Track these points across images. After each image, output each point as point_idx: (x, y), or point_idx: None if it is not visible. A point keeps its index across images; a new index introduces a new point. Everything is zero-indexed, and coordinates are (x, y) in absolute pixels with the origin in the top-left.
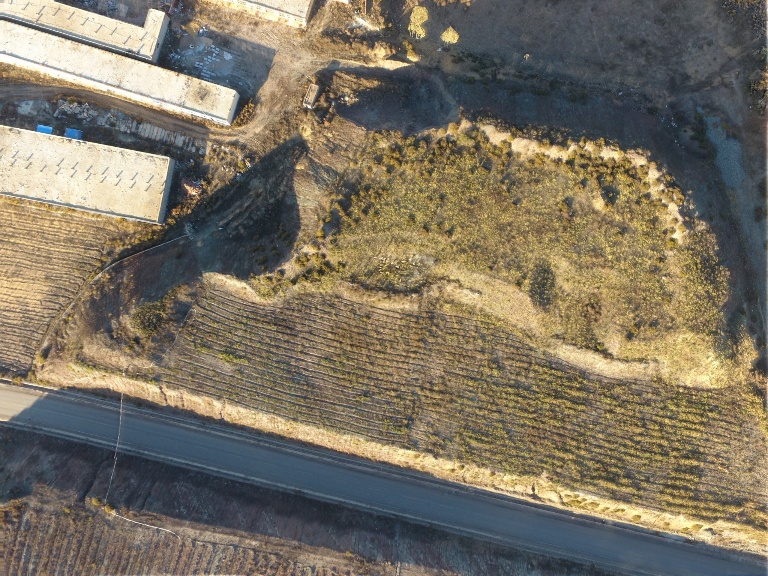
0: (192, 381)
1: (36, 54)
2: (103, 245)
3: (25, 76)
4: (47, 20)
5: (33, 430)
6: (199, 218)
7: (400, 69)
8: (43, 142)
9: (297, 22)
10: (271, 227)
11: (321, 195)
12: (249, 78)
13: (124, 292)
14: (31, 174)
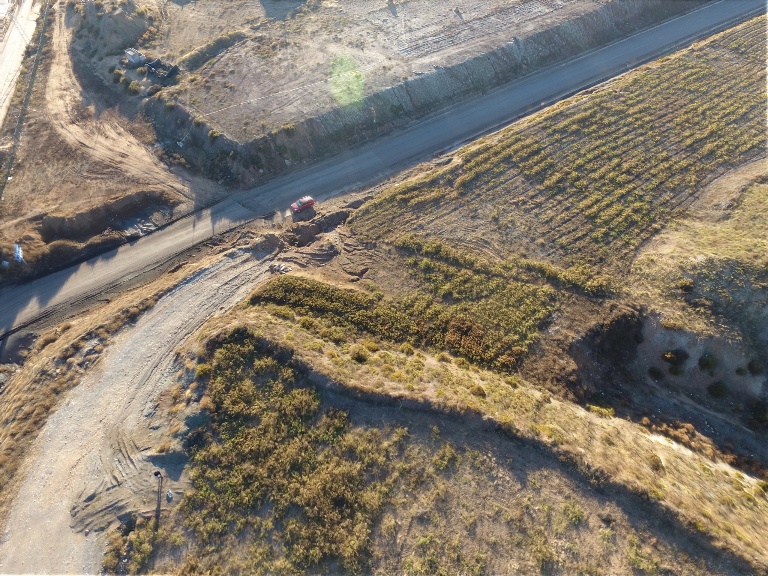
0: None
1: None
2: None
3: None
4: None
5: None
6: None
7: None
8: None
9: None
10: None
11: None
12: None
13: None
14: None
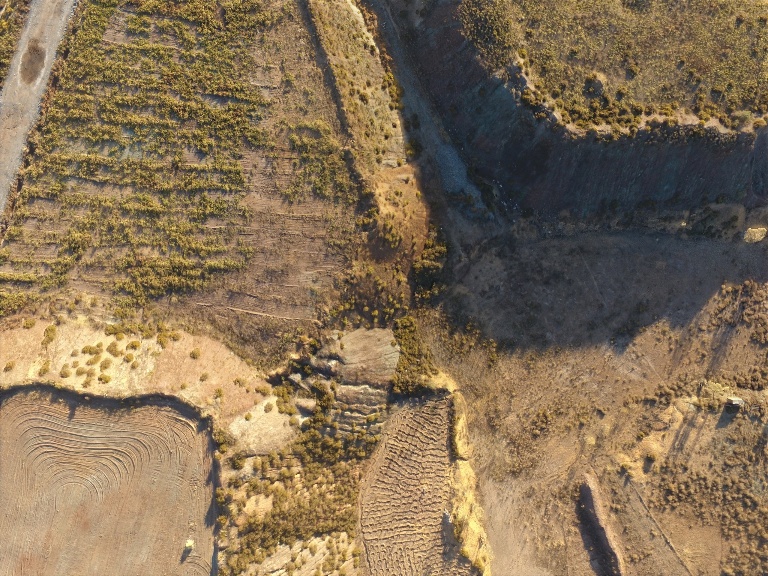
0: None
1: None
2: None
3: None
4: None
5: None
6: None
7: None
8: None
9: None
10: None
11: None
12: None
13: None
14: None
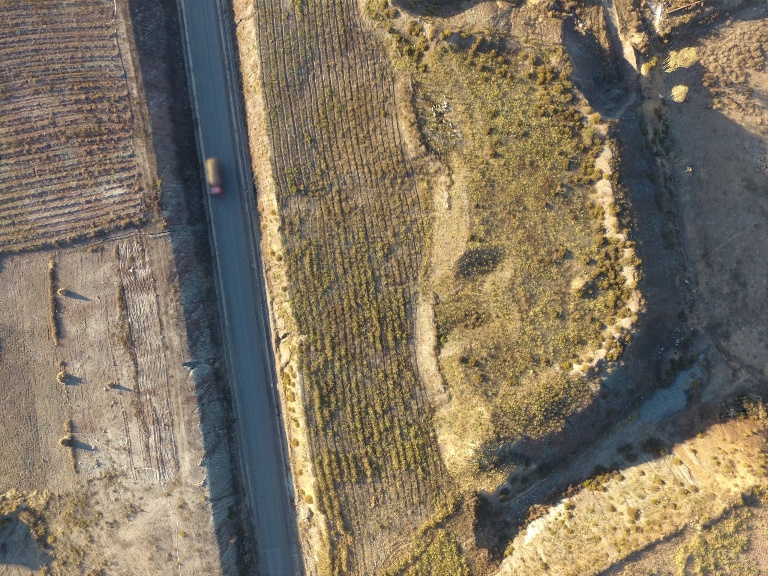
0: None
1: None
2: None
3: None
4: None
5: None
6: None
7: (628, 64)
8: None
9: None
10: None
11: (483, 23)
12: None
13: None
14: None
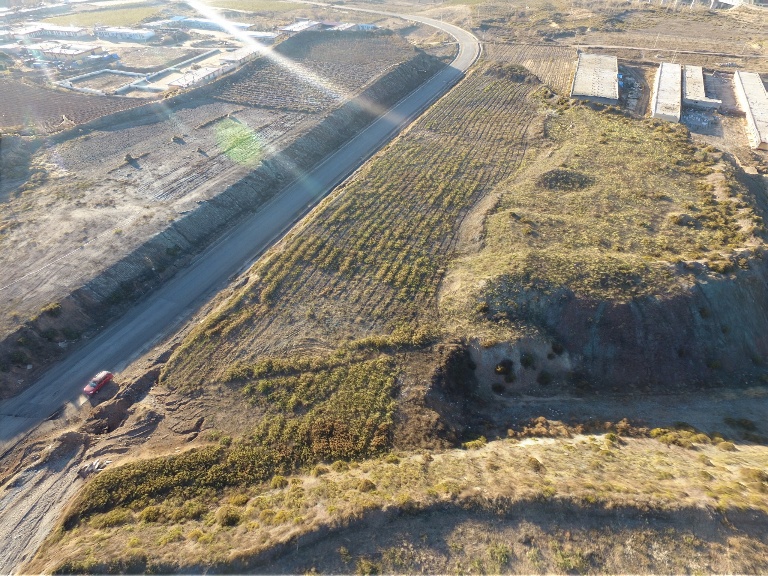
0: None
1: None
2: None
3: (650, 79)
4: (689, 79)
5: None
6: None
7: (749, 175)
8: None
9: None
10: None
11: None
12: None
13: None
14: None
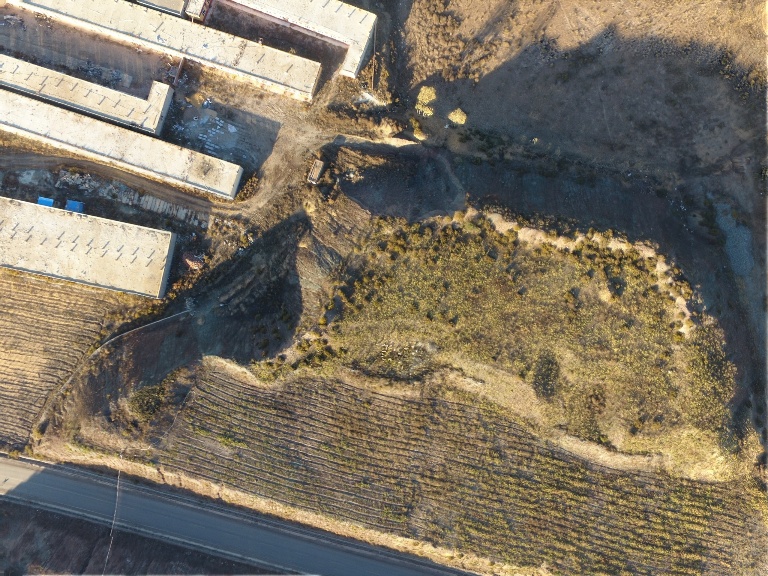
0: (190, 464)
1: (38, 125)
2: (103, 318)
3: (27, 145)
4: (50, 91)
5: (29, 504)
6: (200, 293)
7: (406, 146)
8: (44, 214)
9: (303, 96)
10: (273, 306)
11: (324, 280)
12: (253, 151)
13: (123, 371)
14: (31, 247)
